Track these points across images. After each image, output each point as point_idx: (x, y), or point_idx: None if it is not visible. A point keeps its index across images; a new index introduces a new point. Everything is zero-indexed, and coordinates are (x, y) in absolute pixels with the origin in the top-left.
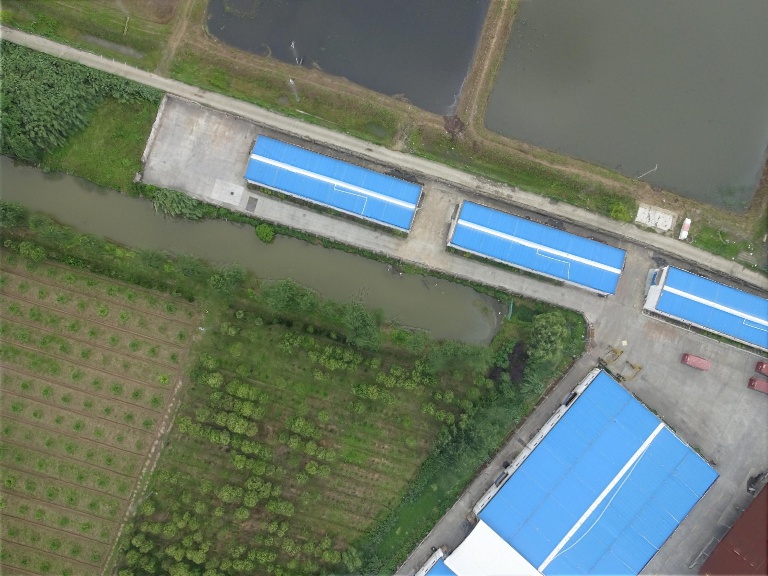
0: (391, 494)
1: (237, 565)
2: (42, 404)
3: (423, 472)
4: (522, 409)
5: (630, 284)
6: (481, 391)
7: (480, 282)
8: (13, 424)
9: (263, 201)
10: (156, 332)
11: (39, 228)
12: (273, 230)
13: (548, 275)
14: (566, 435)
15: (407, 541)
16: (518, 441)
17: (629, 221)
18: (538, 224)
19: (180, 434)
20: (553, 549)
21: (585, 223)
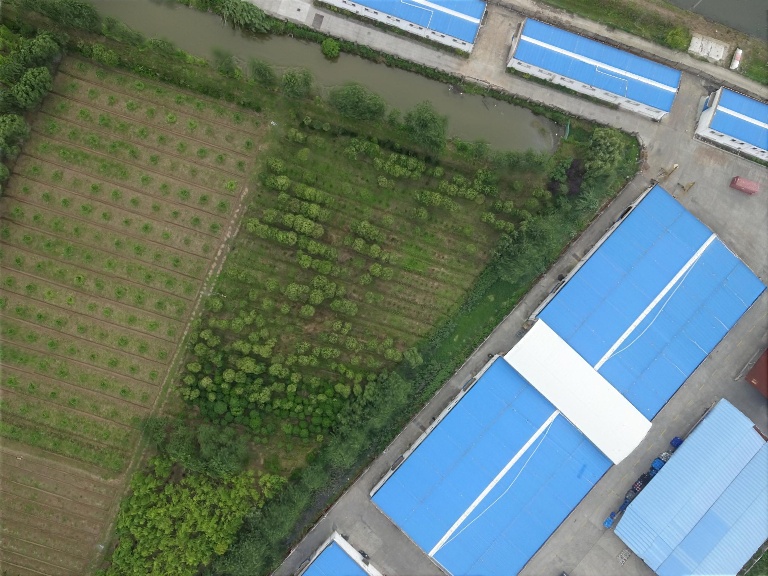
0: (450, 302)
1: (303, 359)
2: (111, 207)
3: (482, 281)
4: (577, 225)
5: (682, 110)
6: (538, 207)
7: (539, 102)
8: (82, 225)
9: (329, 18)
10: (223, 141)
11: (111, 32)
12: (339, 45)
13: (605, 95)
14: (622, 244)
15: (465, 347)
16: (573, 256)
17: (683, 49)
18: (598, 43)
19: (246, 239)
20: (608, 350)
21: (640, 50)
